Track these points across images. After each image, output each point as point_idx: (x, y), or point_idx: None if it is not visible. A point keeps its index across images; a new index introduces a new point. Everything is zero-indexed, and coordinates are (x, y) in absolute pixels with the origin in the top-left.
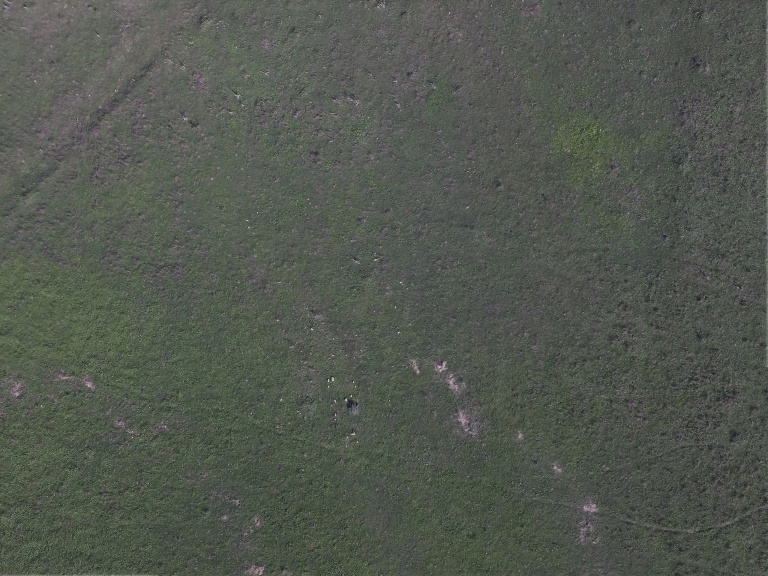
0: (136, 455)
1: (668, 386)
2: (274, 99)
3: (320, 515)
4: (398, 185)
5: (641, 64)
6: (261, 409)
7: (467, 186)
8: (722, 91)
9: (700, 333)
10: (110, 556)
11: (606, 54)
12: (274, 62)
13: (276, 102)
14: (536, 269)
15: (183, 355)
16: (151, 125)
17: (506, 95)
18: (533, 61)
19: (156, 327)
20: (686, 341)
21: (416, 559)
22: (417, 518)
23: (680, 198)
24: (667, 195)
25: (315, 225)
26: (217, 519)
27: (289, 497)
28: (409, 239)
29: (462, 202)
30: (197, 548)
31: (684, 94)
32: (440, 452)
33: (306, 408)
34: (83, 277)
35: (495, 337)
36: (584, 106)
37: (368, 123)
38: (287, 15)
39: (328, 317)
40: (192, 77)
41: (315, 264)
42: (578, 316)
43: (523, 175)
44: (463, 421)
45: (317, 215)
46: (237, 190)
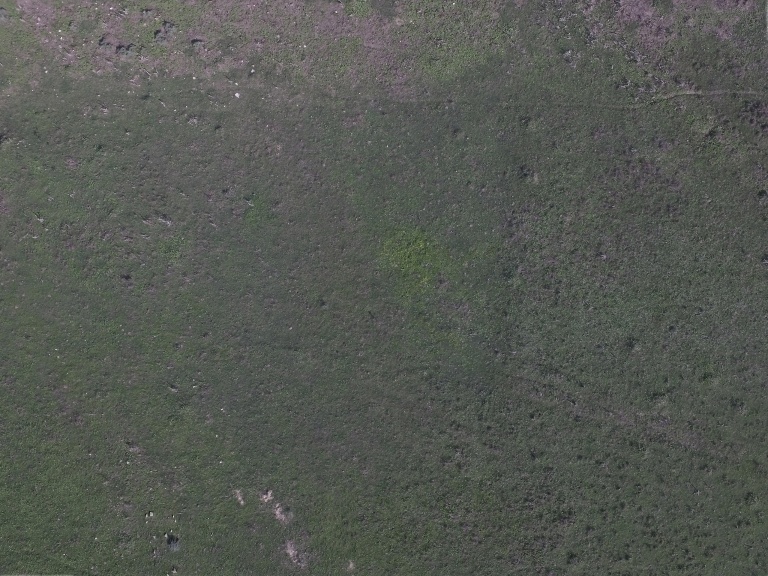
0: None
1: (503, 507)
2: (81, 222)
3: None
4: (217, 307)
5: (468, 174)
6: (74, 549)
7: (290, 306)
8: (551, 201)
9: (534, 452)
10: None
11: (432, 165)
12: (79, 183)
13: (83, 225)
14: (364, 390)
15: None
16: None
17: (329, 210)
18: (357, 174)
19: None
20: (520, 460)
21: None
22: None
23: (511, 312)
24: (498, 309)
25: (129, 352)
26: None
27: None
28: (230, 363)
29: (285, 323)
30: None
31: (513, 205)
32: None
33: (123, 546)
34: None
35: (323, 463)
36: (411, 219)
37: (182, 244)
38: (93, 133)
39: (145, 449)
40: None
41: (130, 393)
42: (409, 438)
43: (348, 293)
44: (291, 552)
45: (131, 342)
46: (45, 317)
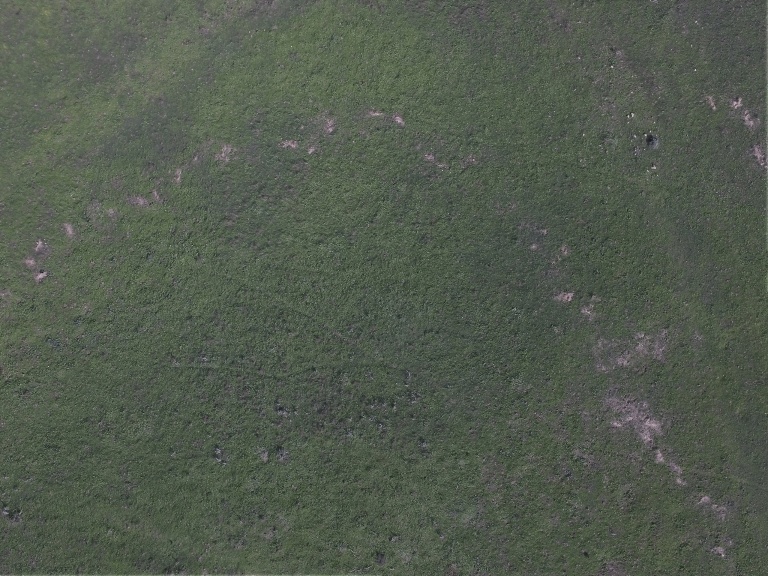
0: (446, 187)
1: None
2: None
3: (625, 244)
4: None
5: None
6: (564, 144)
7: None
8: None
9: None
10: (424, 283)
11: None
12: None
13: None
14: None
15: (488, 93)
16: None
17: None
18: None
19: (461, 66)
20: None
21: (717, 288)
22: (717, 248)
23: None
24: None
25: None
26: (526, 248)
27: (594, 227)
28: None
29: None
30: (508, 275)
31: None
32: (737, 186)
33: (608, 142)
34: (390, 19)
35: None
36: None
37: None
38: None
39: (627, 55)
40: None
41: (613, 4)
42: None
43: None
44: (759, 156)
45: None
46: None
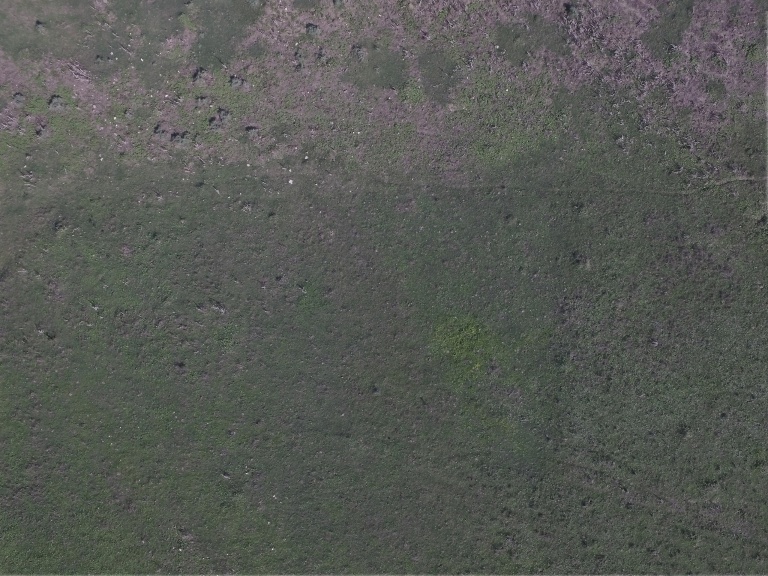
0: None
1: None
2: (135, 309)
3: None
4: (269, 394)
5: (520, 260)
6: None
7: (342, 392)
8: (603, 287)
9: (585, 539)
10: None
11: (484, 250)
12: (134, 271)
13: (137, 312)
14: (416, 476)
15: None
16: (5, 338)
17: (381, 296)
18: (409, 259)
19: (13, 553)
20: (572, 547)
21: None
22: None
23: (563, 398)
24: (550, 395)
25: (182, 439)
26: None
27: None
28: (282, 450)
29: (337, 409)
30: None
31: (565, 290)
32: None
33: None
34: None
35: (374, 549)
36: (463, 305)
37: (236, 331)
38: (147, 220)
39: (197, 536)
40: (48, 286)
41: (183, 480)
42: (460, 524)
43: (400, 379)
44: None
45: (184, 429)
46: (98, 404)
